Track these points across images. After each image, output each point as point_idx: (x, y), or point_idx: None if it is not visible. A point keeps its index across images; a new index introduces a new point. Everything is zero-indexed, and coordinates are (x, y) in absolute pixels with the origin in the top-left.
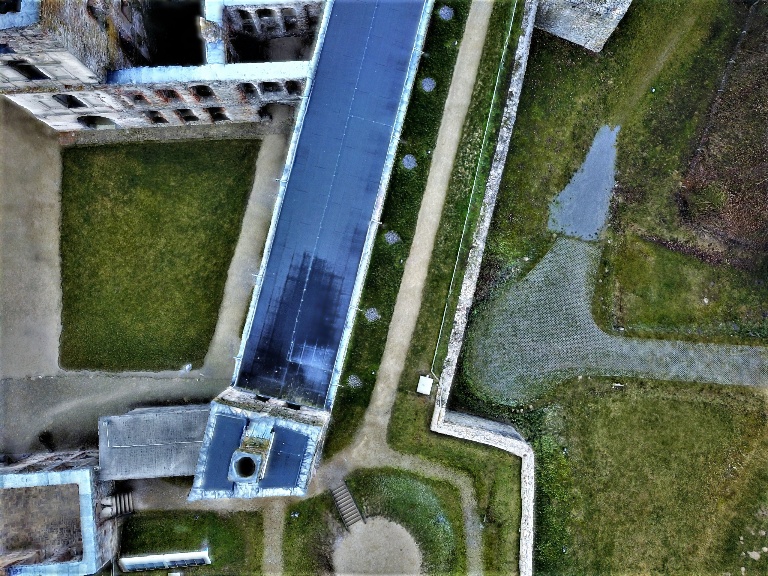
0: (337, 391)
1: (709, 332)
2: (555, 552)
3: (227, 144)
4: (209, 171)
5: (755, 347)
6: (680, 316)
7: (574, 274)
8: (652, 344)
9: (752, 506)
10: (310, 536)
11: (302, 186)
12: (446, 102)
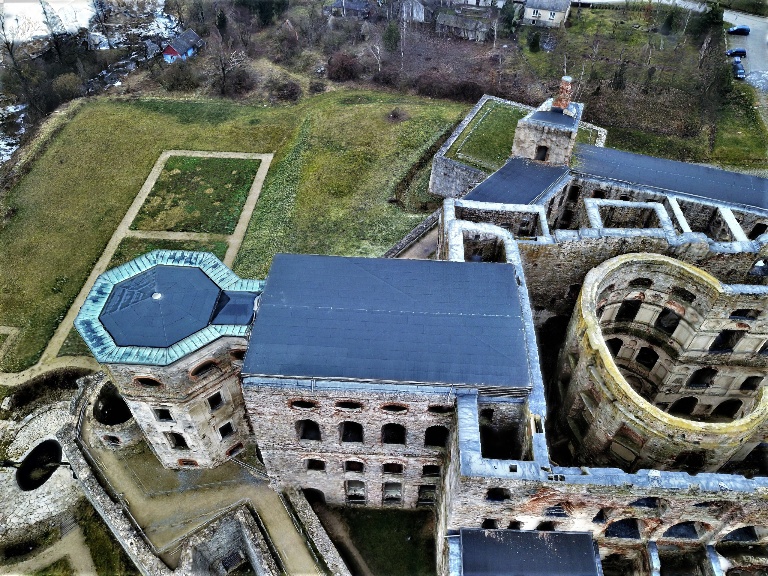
0: None
1: (760, 131)
2: None
3: None
4: None
5: (762, 117)
6: (754, 141)
7: None
8: None
9: None
10: None
11: None
12: None
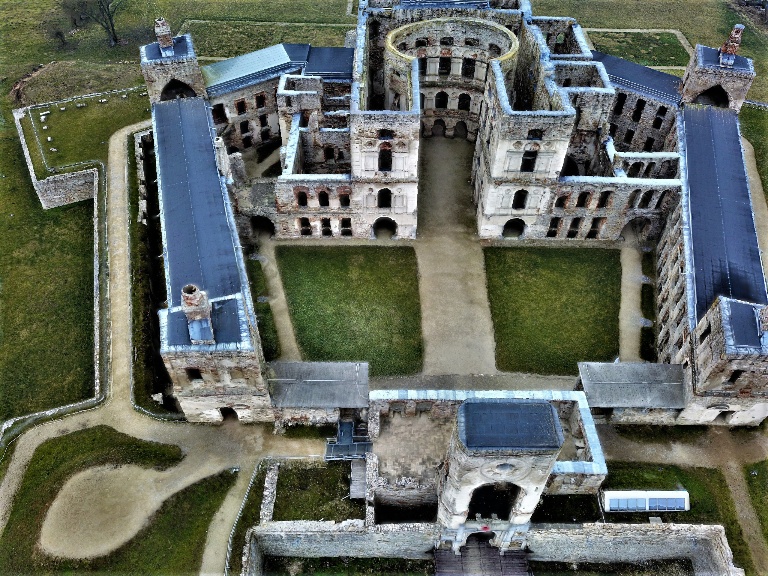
0: None
1: None
2: None
3: (597, 250)
4: (588, 262)
5: None
6: None
7: None
8: None
9: None
10: None
11: (702, 228)
12: (755, 224)
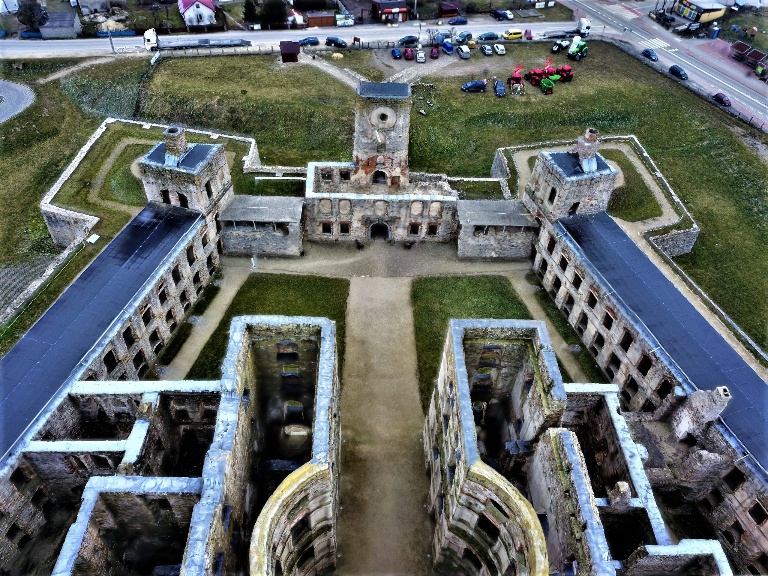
0: None
1: None
2: None
3: None
4: None
5: None
6: None
7: None
8: None
9: None
10: None
11: (113, 306)
12: None
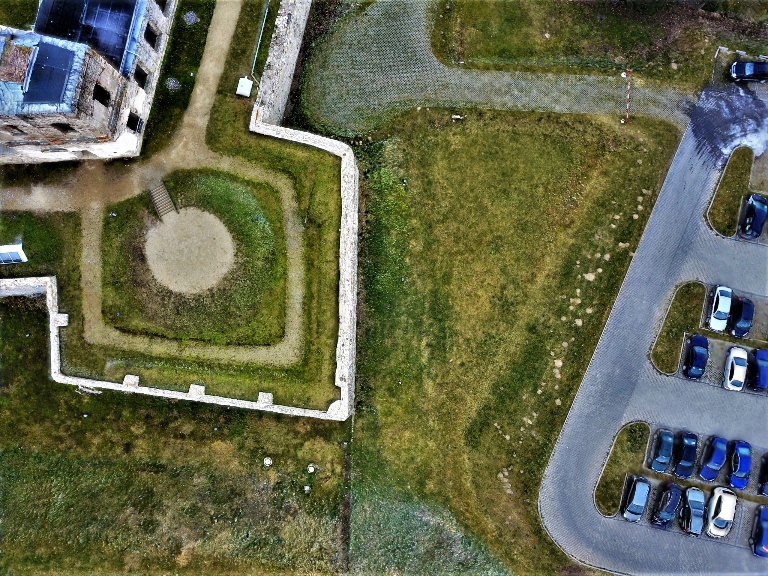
0: (155, 93)
1: (549, 64)
2: (394, 281)
3: None
4: None
5: (593, 76)
6: (521, 50)
7: (414, 9)
8: (491, 75)
9: (589, 232)
10: (127, 233)
11: None
12: None
